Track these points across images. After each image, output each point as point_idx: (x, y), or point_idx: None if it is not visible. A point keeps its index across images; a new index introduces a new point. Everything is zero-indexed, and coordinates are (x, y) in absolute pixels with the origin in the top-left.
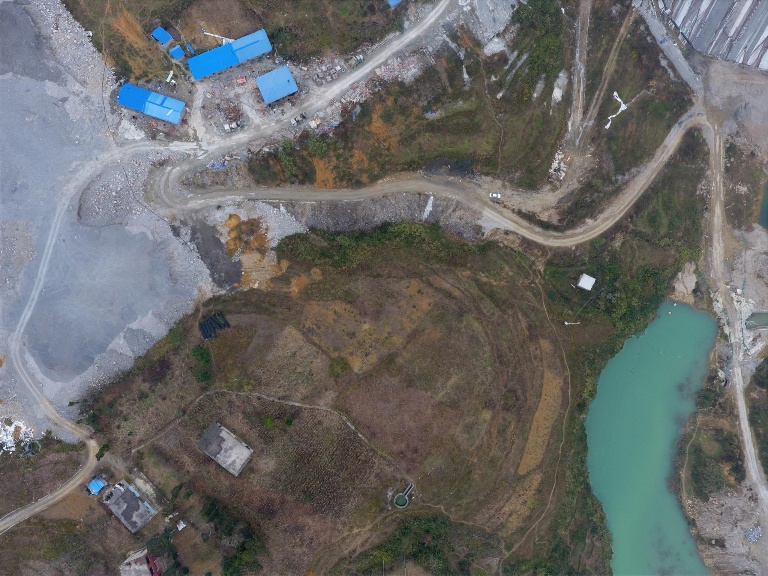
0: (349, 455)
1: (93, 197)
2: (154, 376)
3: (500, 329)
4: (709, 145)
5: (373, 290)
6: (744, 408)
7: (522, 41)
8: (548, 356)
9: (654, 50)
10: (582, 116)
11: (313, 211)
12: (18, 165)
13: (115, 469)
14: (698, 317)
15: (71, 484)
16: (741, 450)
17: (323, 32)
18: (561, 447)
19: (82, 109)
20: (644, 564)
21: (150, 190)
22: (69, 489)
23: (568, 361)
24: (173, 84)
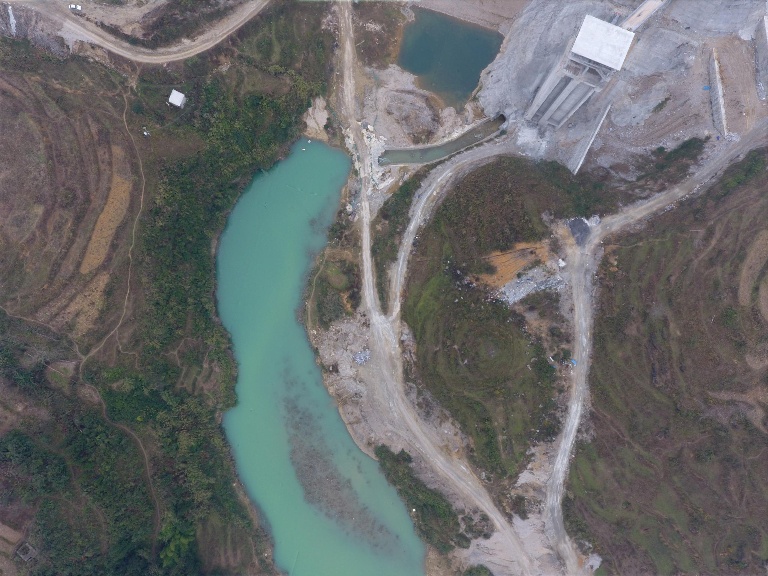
0: None
1: None
2: None
3: (63, 131)
4: None
5: None
6: (368, 240)
7: None
8: (119, 162)
9: None
10: None
11: None
12: None
13: None
14: (332, 154)
15: None
16: (360, 279)
17: None
18: (130, 251)
19: None
20: (270, 393)
21: None
22: None
23: (144, 169)
24: None
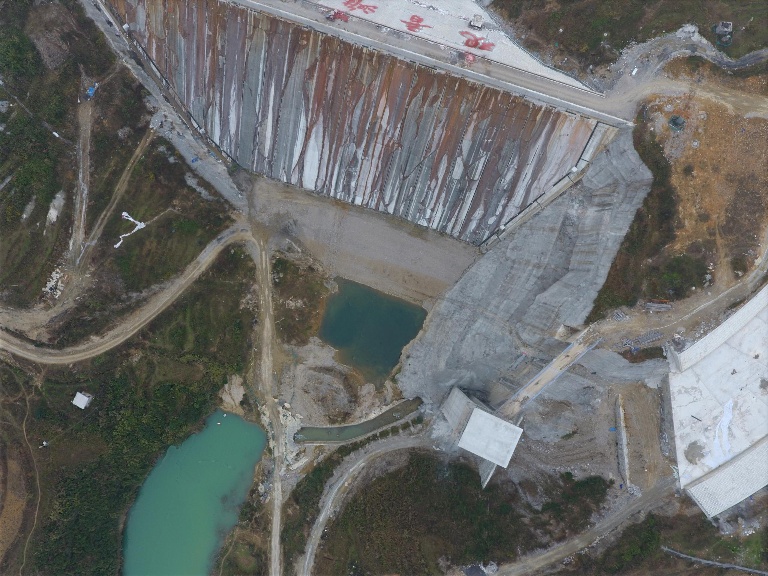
0: None
1: None
2: None
3: None
4: (255, 260)
5: None
6: (278, 524)
7: (2, 165)
8: (14, 478)
9: (177, 170)
10: (84, 236)
11: None
12: None
13: None
14: (248, 429)
15: None
16: (267, 568)
17: None
18: (21, 570)
19: None
20: None
21: None
22: None
23: (41, 482)
24: None
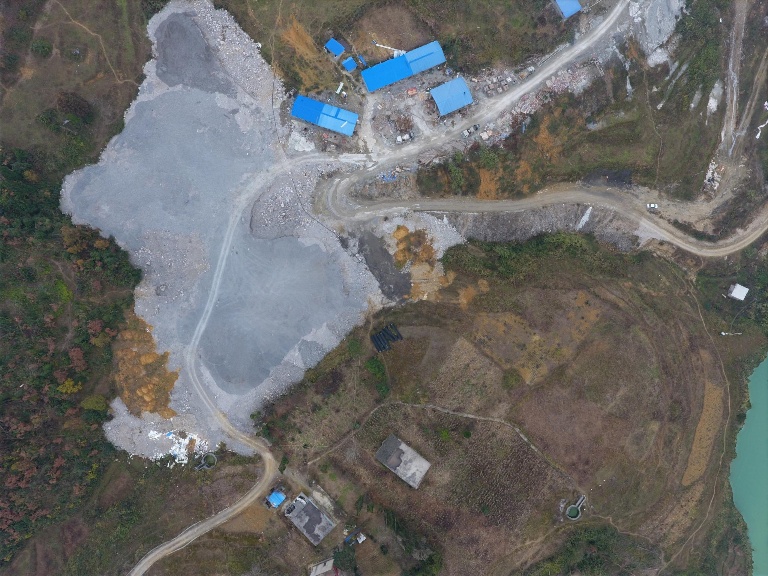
0: (523, 467)
1: (262, 209)
2: (328, 388)
3: (664, 340)
4: None
5: (542, 301)
6: None
7: (683, 52)
8: (708, 367)
9: None
10: (735, 126)
11: (474, 222)
12: (190, 177)
13: (292, 482)
14: None
15: (250, 497)
16: None
17: (494, 43)
18: (722, 458)
19: (252, 121)
20: None
21: (318, 202)
22: (248, 502)
23: (726, 371)
24: (344, 96)
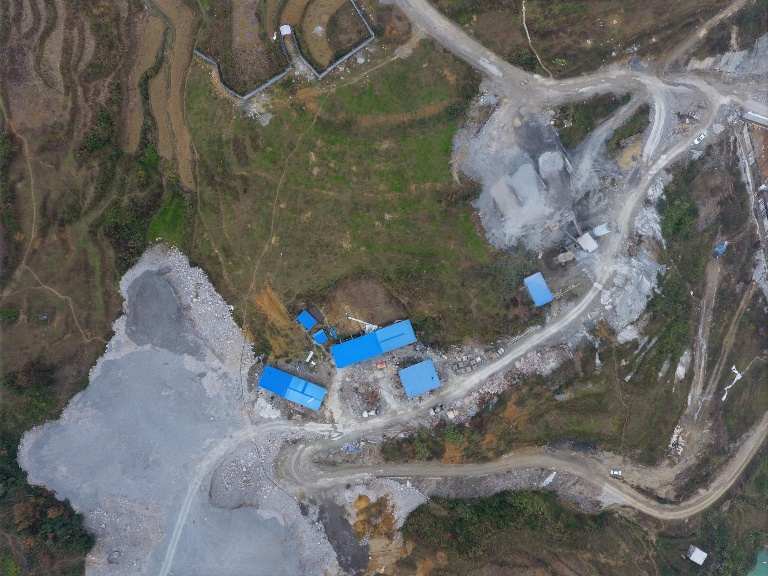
0: None
1: (223, 472)
2: None
3: None
4: None
5: None
6: None
7: None
8: None
9: None
10: (702, 391)
11: (437, 485)
12: (151, 440)
13: None
14: None
15: None
16: None
17: (465, 322)
18: None
19: (219, 385)
20: None
21: (280, 466)
22: None
23: None
24: (313, 366)
